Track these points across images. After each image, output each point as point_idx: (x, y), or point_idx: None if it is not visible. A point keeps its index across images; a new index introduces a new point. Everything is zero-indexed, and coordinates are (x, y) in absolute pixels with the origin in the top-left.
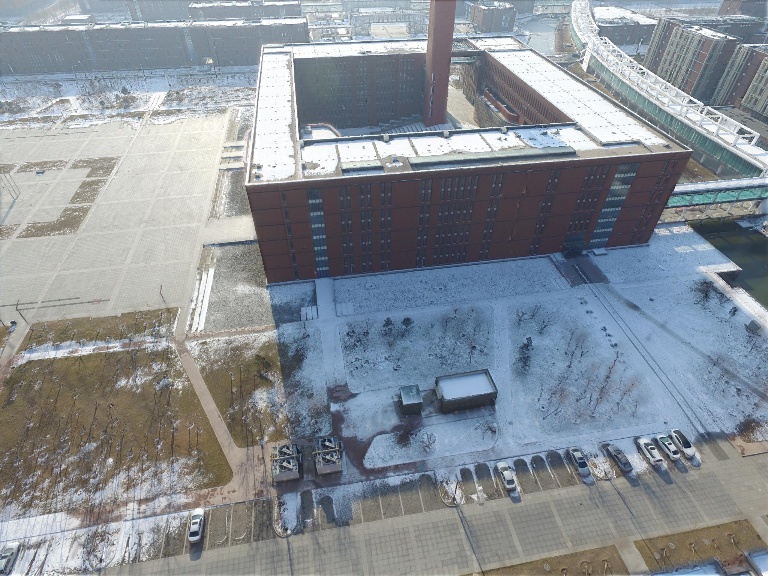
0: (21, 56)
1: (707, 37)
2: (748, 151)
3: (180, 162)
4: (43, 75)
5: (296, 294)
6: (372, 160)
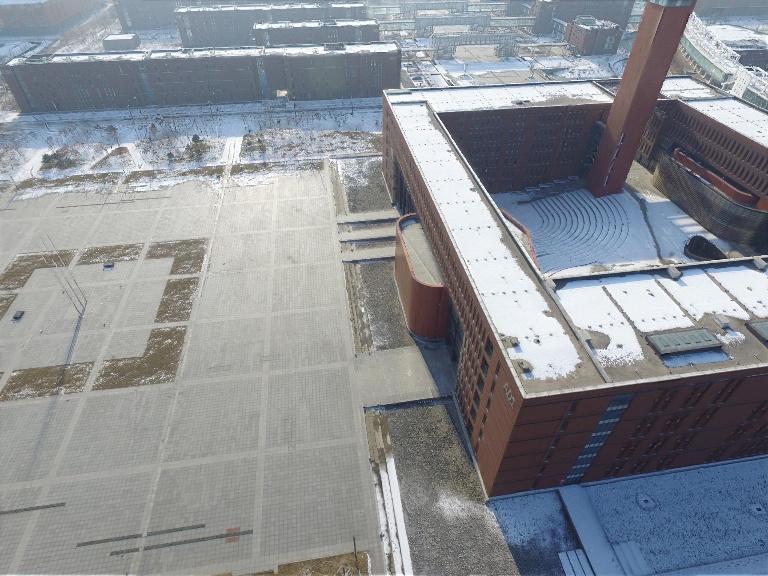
0: (66, 90)
1: None
2: None
3: (288, 249)
4: (91, 112)
5: (538, 519)
6: (696, 330)
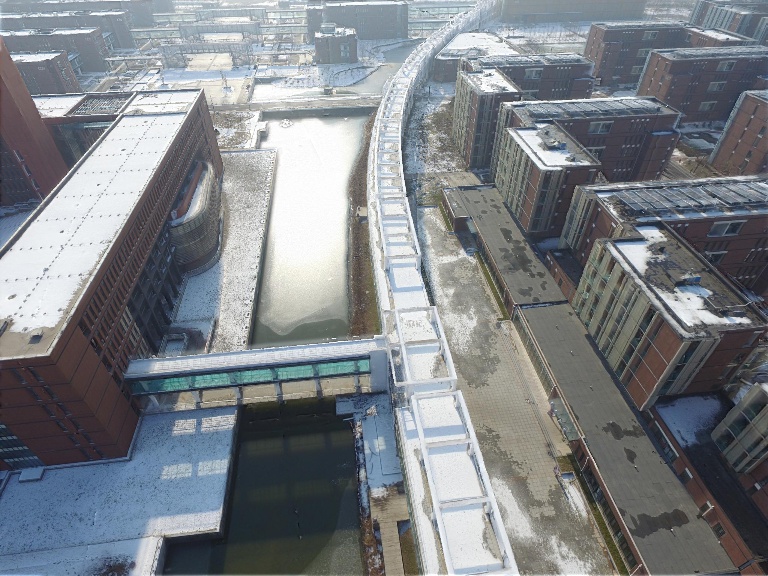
0: None
1: (475, 89)
2: (398, 281)
3: None
4: None
5: None
6: None
